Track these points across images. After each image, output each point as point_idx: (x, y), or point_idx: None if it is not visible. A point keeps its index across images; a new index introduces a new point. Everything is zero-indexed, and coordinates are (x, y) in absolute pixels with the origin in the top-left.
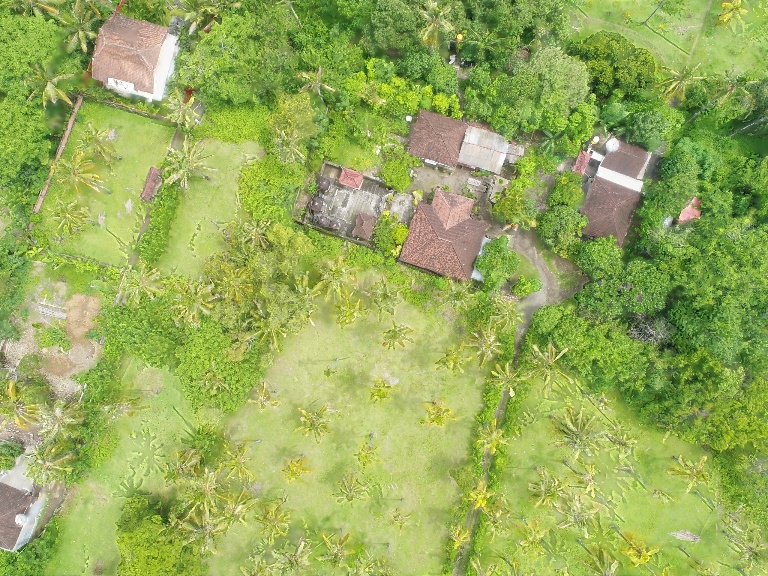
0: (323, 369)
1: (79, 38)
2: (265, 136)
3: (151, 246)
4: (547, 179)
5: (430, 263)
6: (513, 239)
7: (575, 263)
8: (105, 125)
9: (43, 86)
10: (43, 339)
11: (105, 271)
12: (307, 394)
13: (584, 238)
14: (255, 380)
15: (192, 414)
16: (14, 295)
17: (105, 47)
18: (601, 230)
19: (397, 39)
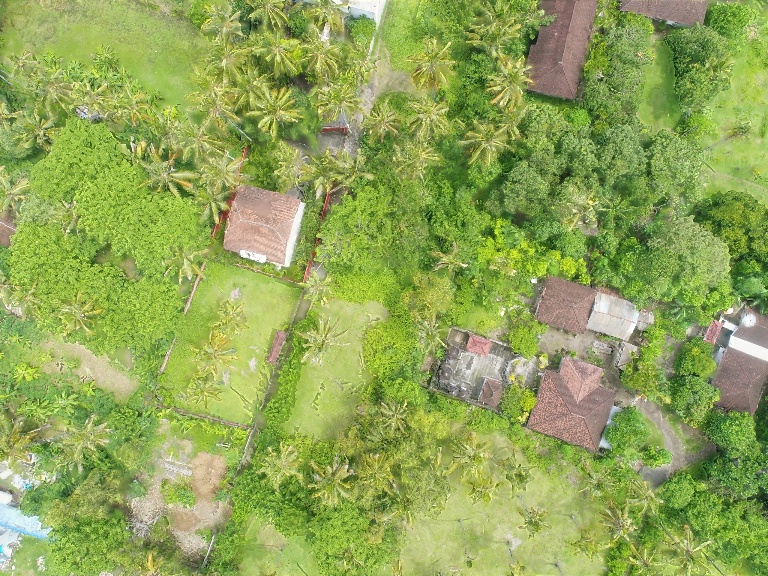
0: (446, 529)
1: (211, 209)
2: (390, 299)
3: (280, 413)
4: (674, 342)
5: (558, 432)
6: (638, 403)
7: (704, 432)
8: (229, 283)
9: (180, 263)
10: (170, 496)
11: (231, 431)
12: (429, 553)
13: (714, 407)
14: (390, 558)
15: (316, 571)
16: (142, 454)
17: (240, 223)
18: (733, 403)
19: (528, 207)
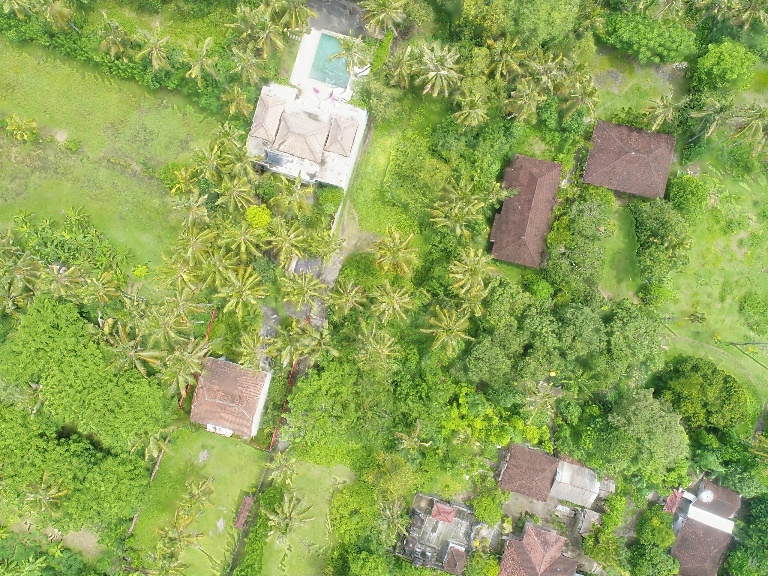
0: None
1: (178, 382)
2: (357, 464)
3: None
4: None
5: None
6: None
7: None
8: (197, 445)
9: (146, 442)
10: None
11: None
12: None
13: (674, 575)
14: None
15: None
16: None
17: (206, 401)
18: (692, 573)
19: (491, 380)
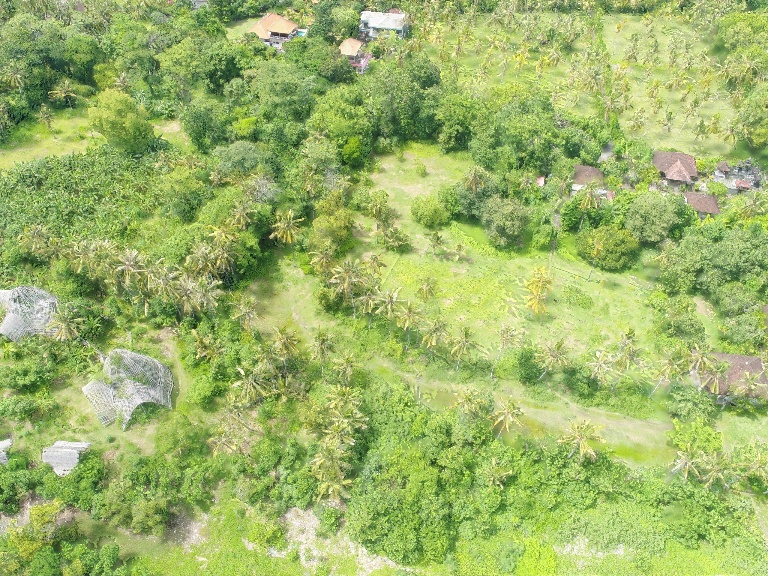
0: None
1: None
2: None
3: None
4: None
5: None
6: None
7: None
8: None
9: None
10: None
11: None
12: (707, 123)
13: None
14: None
15: None
16: None
17: None
18: None
19: None
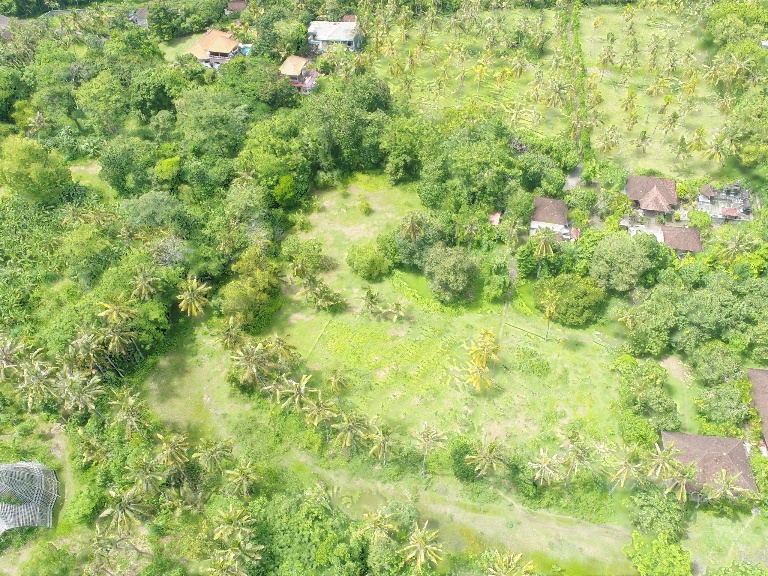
0: None
1: None
2: None
3: None
4: None
5: None
6: None
7: None
8: None
9: None
10: None
11: None
12: None
13: None
14: None
15: None
16: None
17: None
18: None
19: None
